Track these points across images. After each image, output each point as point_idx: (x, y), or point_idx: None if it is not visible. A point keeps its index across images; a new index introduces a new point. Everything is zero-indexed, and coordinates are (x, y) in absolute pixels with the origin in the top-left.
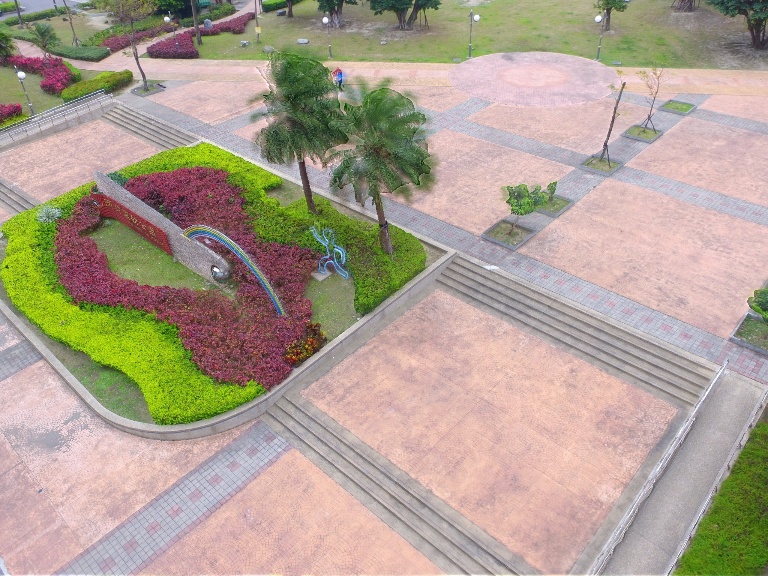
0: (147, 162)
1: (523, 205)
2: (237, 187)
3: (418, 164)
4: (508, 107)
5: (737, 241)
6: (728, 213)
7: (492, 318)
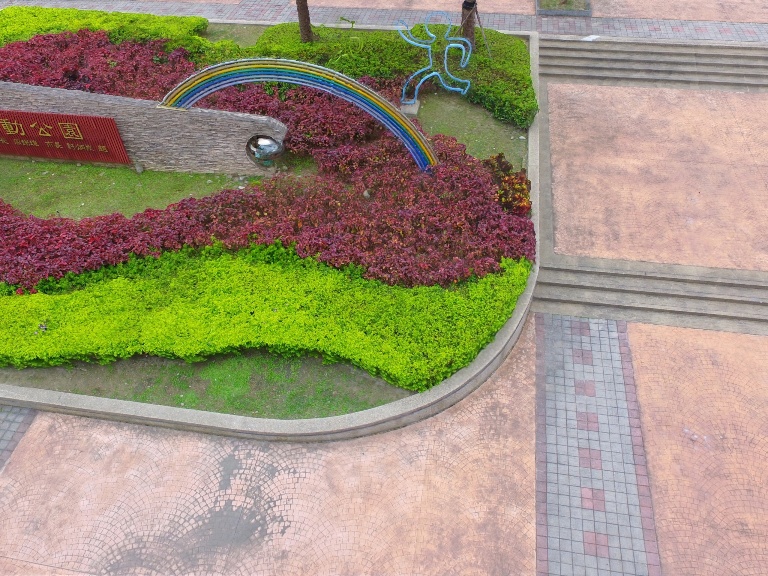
0: None
1: None
2: (144, 43)
3: None
4: None
5: None
6: None
7: (647, 89)
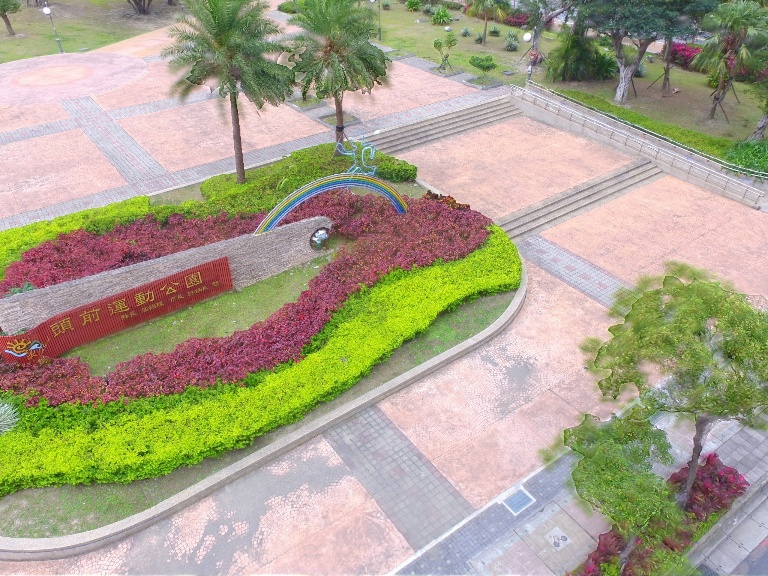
0: None
1: None
2: None
3: None
4: (110, 92)
5: (392, 71)
6: None
7: (426, 148)
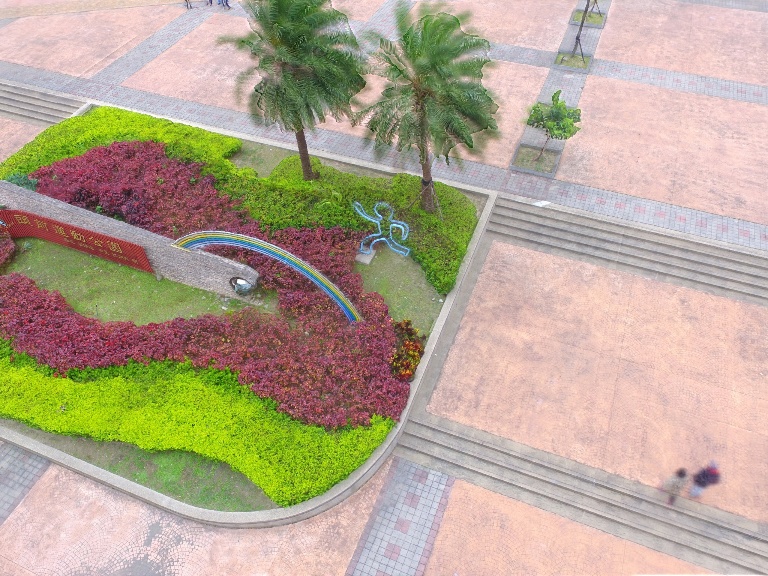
0: (34, 147)
1: (567, 127)
2: (189, 161)
3: (490, 105)
4: (436, 5)
5: (744, 124)
6: (718, 95)
7: (571, 262)
